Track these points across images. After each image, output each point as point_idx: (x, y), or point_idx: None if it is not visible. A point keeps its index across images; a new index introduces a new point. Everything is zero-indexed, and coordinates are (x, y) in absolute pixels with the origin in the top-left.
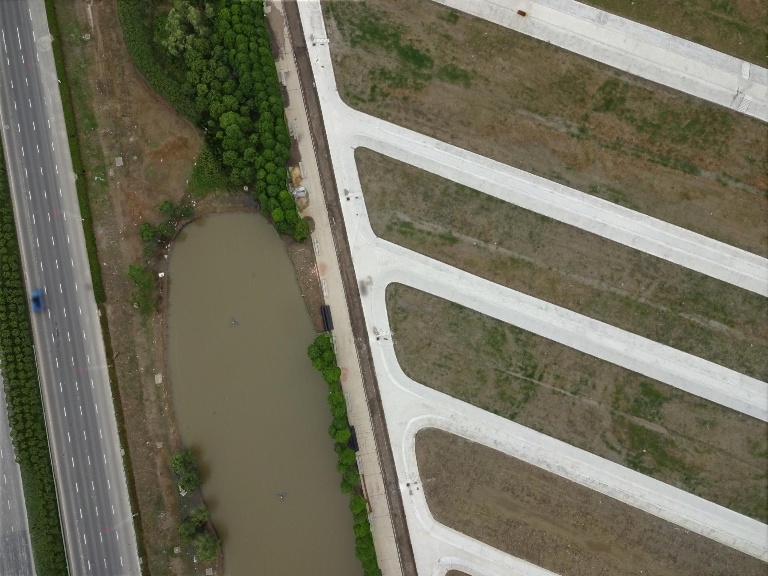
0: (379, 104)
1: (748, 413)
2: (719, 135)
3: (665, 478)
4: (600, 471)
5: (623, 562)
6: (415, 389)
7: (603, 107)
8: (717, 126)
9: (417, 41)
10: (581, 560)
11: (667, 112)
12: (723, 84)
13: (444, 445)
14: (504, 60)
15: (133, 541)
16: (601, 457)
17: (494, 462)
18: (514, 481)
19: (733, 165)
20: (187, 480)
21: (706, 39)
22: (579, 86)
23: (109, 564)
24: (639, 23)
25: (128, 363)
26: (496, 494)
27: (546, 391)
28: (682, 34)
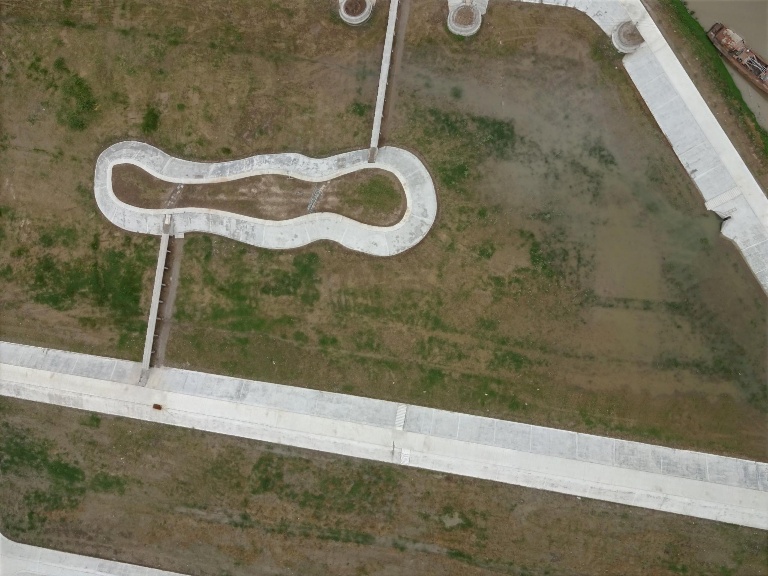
0: (38, 531)
1: None
2: (387, 494)
3: None
4: None
5: None
6: None
7: (261, 488)
8: (382, 485)
9: (64, 454)
10: None
11: (328, 480)
12: (377, 441)
13: None
14: (153, 456)
15: None
16: None
17: None
18: None
19: (407, 525)
20: None
21: (357, 386)
22: (233, 469)
23: None
24: (283, 385)
25: None
26: None
27: None
28: (330, 387)
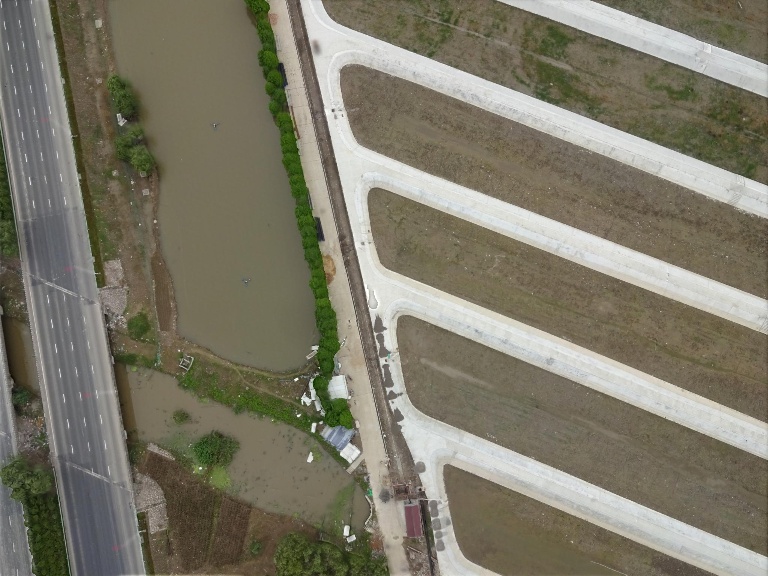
0: None
1: (644, 51)
2: None
3: (570, 107)
4: (510, 98)
5: (533, 180)
6: (340, 29)
7: None
8: None
9: None
10: (494, 178)
11: None
12: None
13: (367, 79)
14: None
15: (72, 160)
16: (512, 89)
17: (413, 94)
18: (432, 110)
19: None
20: (123, 96)
21: None
22: None
23: (49, 180)
24: None
25: (69, 7)
26: (415, 122)
27: (461, 34)
28: None
